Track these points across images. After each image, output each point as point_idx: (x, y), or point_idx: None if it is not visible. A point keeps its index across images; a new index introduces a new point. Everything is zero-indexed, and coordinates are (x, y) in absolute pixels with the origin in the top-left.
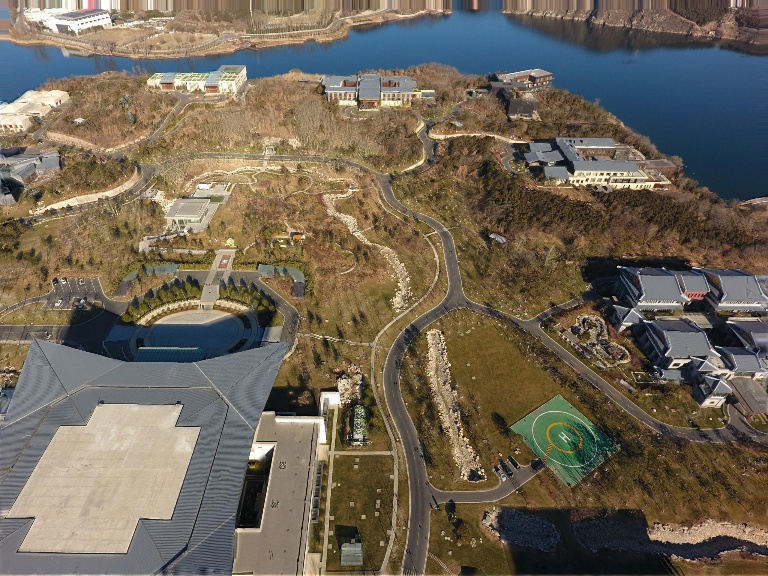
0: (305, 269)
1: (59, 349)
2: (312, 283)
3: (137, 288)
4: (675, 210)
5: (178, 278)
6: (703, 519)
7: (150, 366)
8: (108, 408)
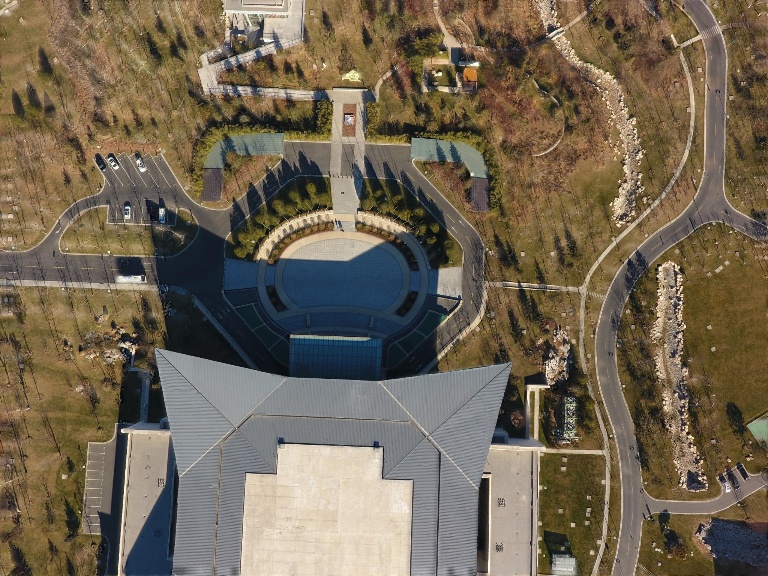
0: (486, 149)
1: (197, 365)
2: (501, 184)
3: (231, 183)
4: None
5: (286, 159)
6: None
7: (323, 386)
8: (293, 451)
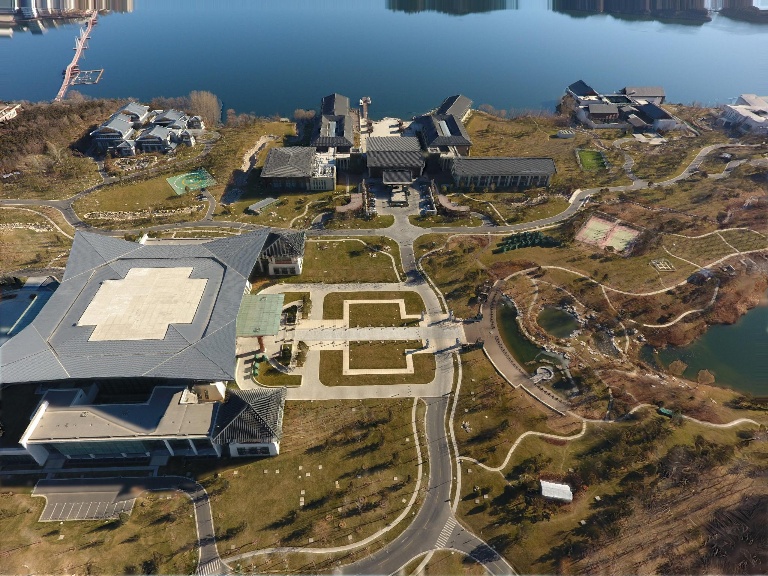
0: None
1: None
2: None
3: None
4: (52, 110)
5: None
6: (242, 158)
7: (49, 306)
8: (84, 318)
